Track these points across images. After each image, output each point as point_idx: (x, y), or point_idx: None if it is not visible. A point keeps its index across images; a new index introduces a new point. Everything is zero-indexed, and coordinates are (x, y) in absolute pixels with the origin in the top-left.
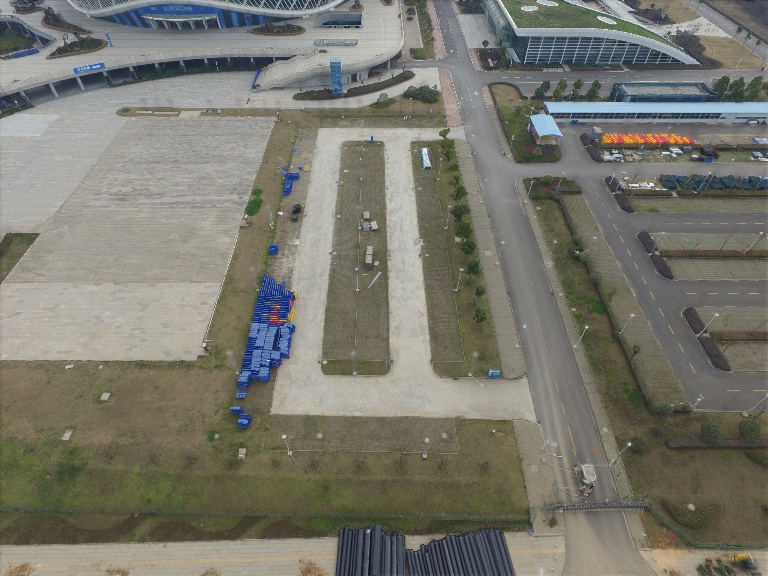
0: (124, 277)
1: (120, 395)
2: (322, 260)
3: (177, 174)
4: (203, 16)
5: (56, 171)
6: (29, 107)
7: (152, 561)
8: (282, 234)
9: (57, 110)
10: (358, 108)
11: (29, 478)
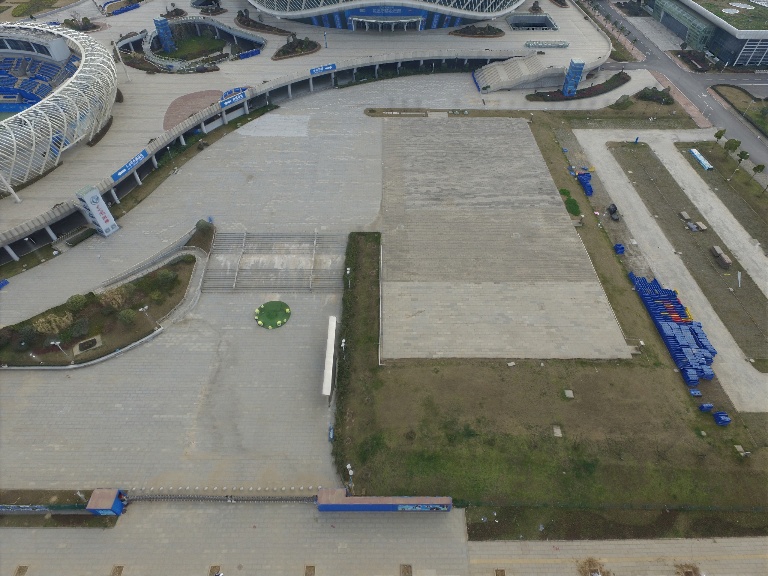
0: (499, 276)
1: (582, 392)
2: (673, 260)
3: (472, 174)
4: (410, 18)
5: (349, 171)
6: (275, 108)
7: (713, 556)
8: (614, 234)
9: (304, 111)
10: (599, 109)
11: (547, 474)
